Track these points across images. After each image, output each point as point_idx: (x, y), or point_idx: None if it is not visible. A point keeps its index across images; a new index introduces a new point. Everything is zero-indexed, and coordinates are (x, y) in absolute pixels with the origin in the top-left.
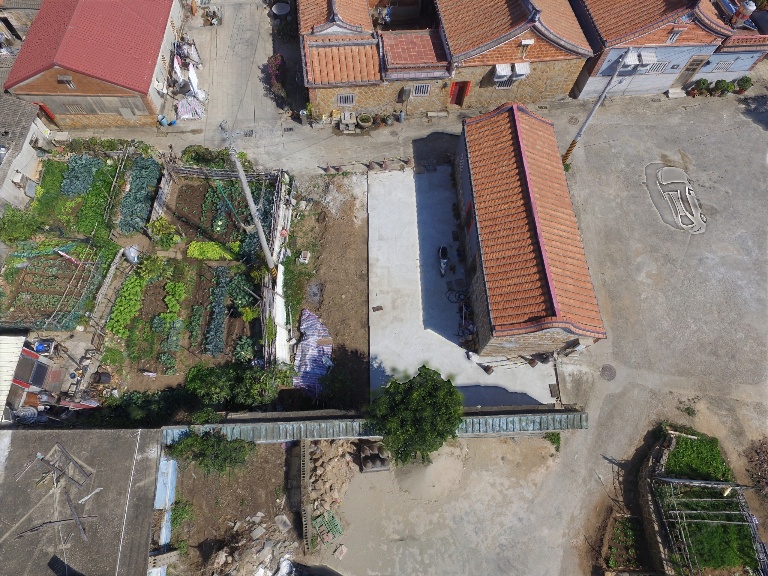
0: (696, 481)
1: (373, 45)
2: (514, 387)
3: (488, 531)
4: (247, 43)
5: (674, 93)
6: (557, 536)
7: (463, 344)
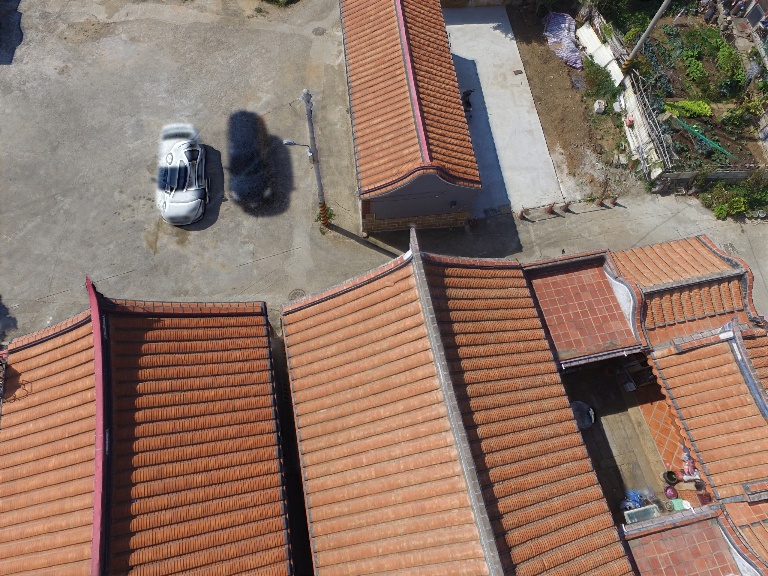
0: None
1: None
2: None
3: None
4: None
5: None
6: None
7: None
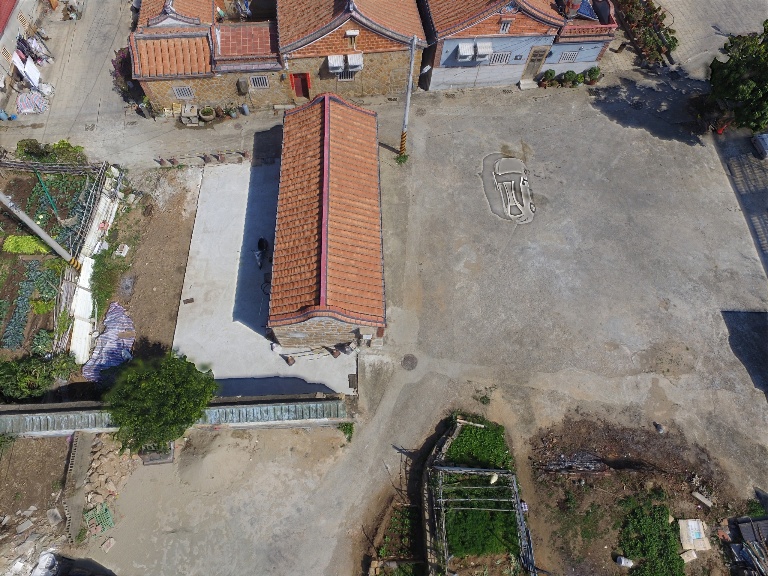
0: (467, 469)
1: (203, 37)
2: (313, 378)
3: (264, 522)
4: (104, 37)
5: (526, 84)
6: (333, 526)
7: (268, 336)
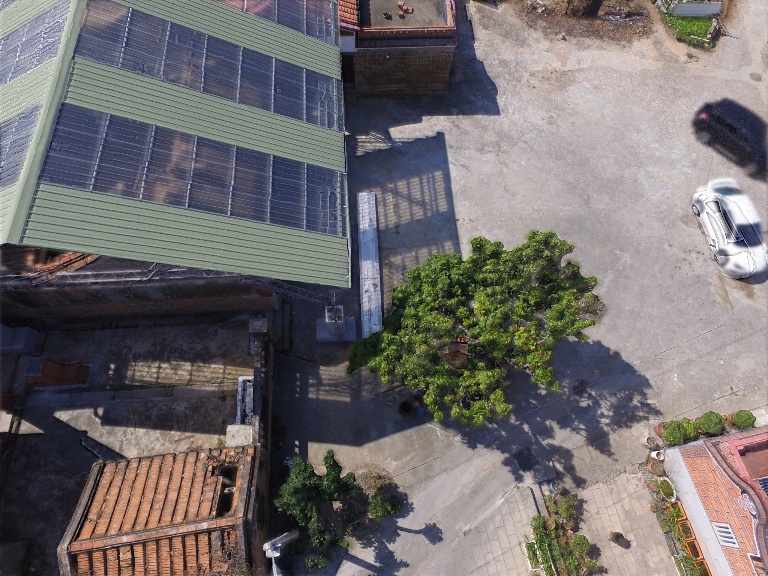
0: (704, 5)
1: None
2: None
3: None
4: None
5: None
6: (754, 6)
7: None
